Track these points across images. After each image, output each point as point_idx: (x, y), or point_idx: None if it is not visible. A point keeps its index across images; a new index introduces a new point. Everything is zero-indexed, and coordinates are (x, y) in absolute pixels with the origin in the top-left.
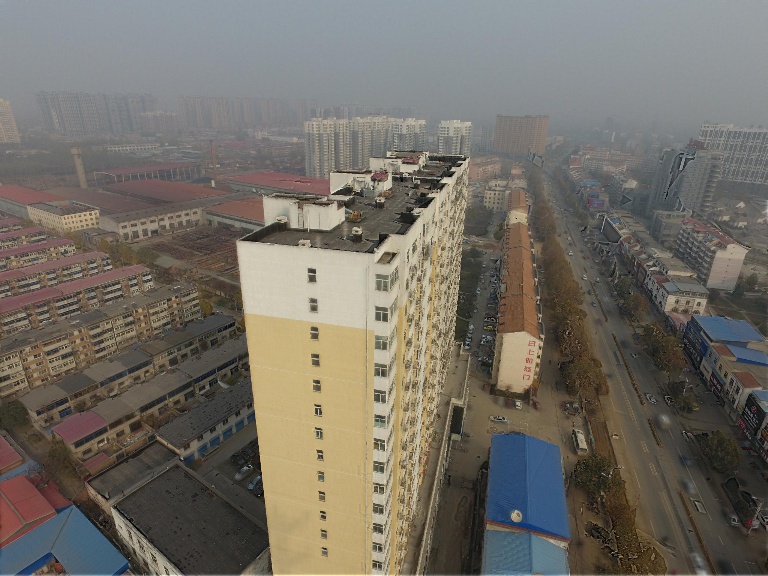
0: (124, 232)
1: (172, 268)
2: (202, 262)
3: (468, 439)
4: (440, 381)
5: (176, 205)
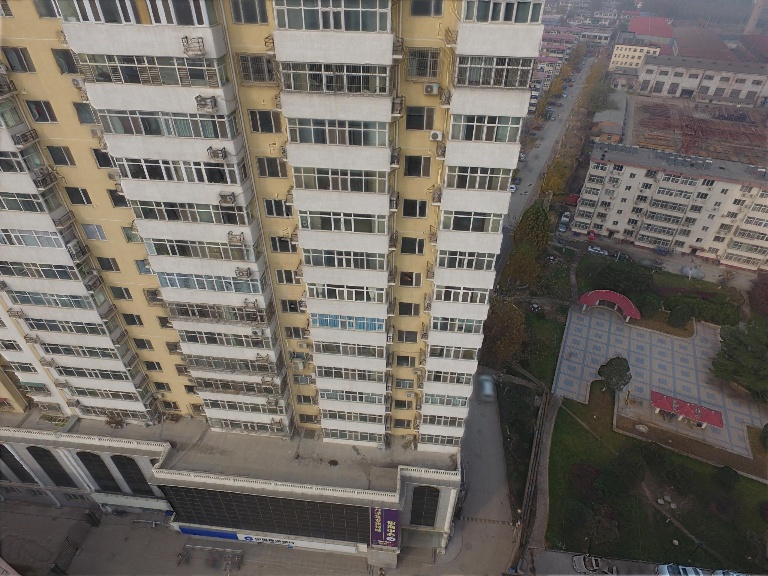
0: (646, 78)
1: (599, 125)
2: (653, 138)
3: (218, 566)
4: (128, 374)
5: (757, 65)
